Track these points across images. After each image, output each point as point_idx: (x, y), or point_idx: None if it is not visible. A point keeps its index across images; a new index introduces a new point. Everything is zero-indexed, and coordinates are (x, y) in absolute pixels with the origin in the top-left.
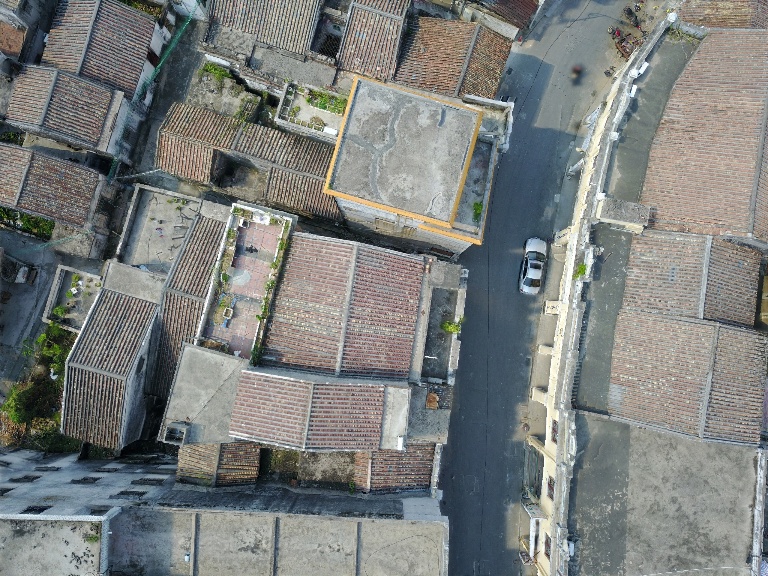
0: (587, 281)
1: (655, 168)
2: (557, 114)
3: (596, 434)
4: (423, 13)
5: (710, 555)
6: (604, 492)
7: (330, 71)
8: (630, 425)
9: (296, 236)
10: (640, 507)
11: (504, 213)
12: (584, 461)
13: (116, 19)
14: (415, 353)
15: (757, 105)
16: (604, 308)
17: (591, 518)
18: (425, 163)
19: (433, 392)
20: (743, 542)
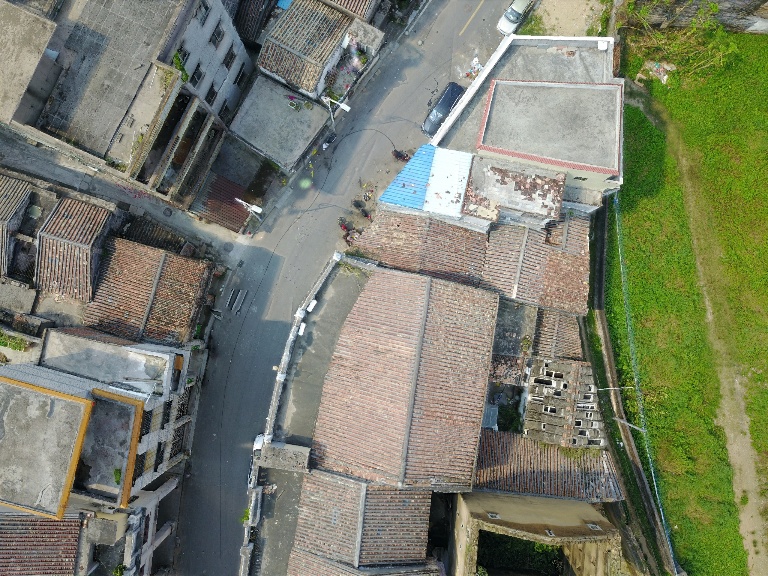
0: None
1: (326, 404)
2: (288, 306)
3: None
4: (137, 220)
5: None
6: None
7: (30, 292)
8: None
9: None
10: None
11: (236, 408)
12: None
13: None
14: None
15: (410, 351)
16: (277, 546)
17: None
18: (34, 455)
19: None
20: None
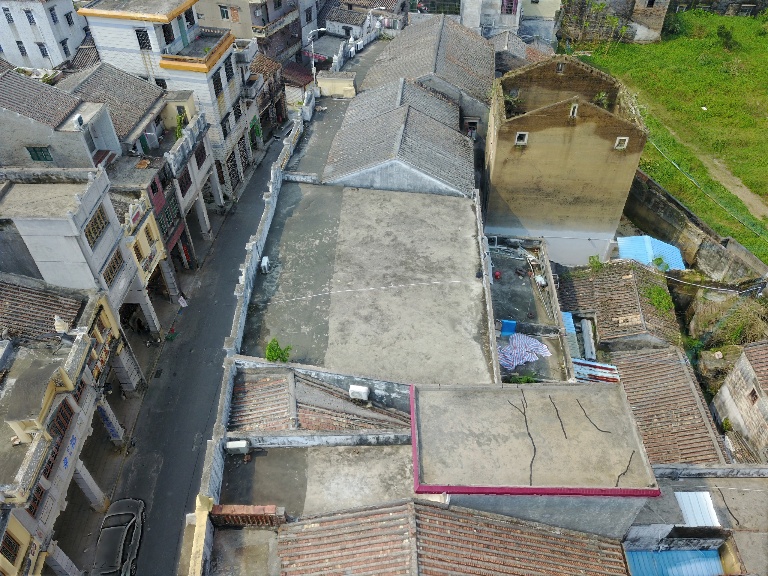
0: (307, 113)
1: (369, 76)
2: None
3: (308, 195)
4: None
5: (433, 272)
6: (312, 231)
7: None
8: (343, 189)
9: (61, 80)
10: (351, 239)
11: None
12: (294, 211)
13: (2, 68)
14: (135, 131)
15: (433, 37)
16: (324, 133)
17: (296, 249)
18: None
19: (146, 160)
20: (470, 262)
